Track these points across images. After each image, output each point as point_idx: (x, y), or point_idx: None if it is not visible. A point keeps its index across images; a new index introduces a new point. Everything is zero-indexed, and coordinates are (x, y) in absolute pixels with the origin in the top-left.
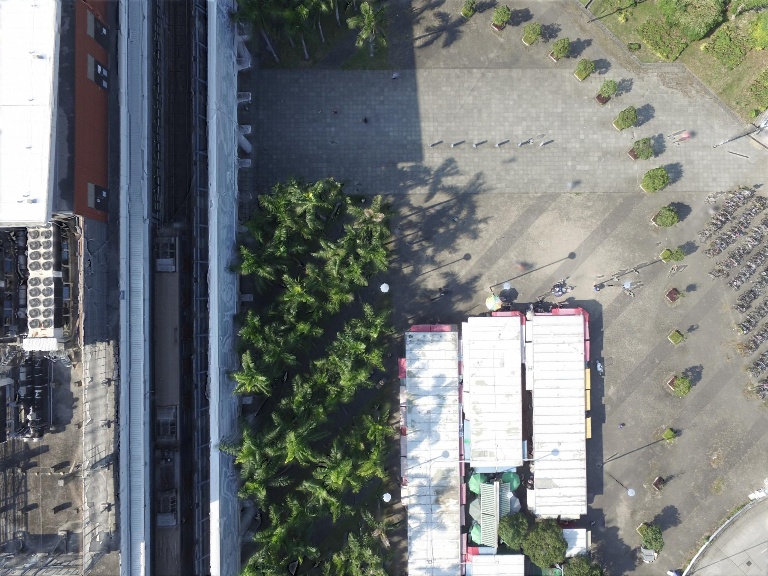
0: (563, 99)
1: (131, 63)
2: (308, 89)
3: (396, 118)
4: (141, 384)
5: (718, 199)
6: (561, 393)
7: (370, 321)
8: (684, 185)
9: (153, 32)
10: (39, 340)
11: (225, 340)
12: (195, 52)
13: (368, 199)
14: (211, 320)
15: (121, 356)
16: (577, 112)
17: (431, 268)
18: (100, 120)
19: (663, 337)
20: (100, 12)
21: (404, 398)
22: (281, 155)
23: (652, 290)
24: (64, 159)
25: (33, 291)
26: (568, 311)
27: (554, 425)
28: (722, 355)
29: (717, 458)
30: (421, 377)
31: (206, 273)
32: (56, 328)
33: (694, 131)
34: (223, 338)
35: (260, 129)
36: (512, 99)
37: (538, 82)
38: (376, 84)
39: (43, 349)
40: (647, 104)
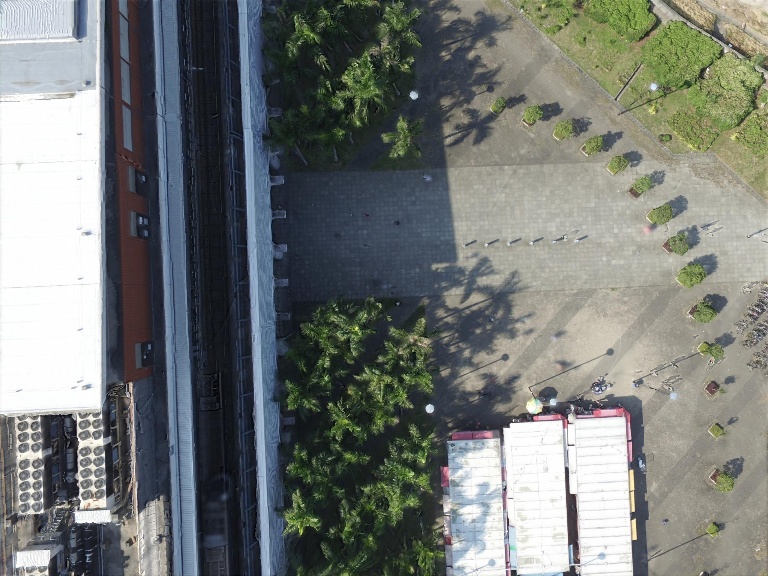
0: (596, 193)
1: (171, 208)
2: (338, 192)
3: (429, 218)
4: (193, 539)
5: (753, 289)
6: (606, 496)
7: (416, 442)
8: (719, 276)
9: (187, 160)
10: (92, 513)
11: (271, 473)
12: (231, 181)
13: (403, 302)
14: (259, 459)
15: (173, 514)
16: (610, 206)
17: (469, 370)
18: (143, 273)
19: (703, 431)
20: (140, 161)
21: (448, 507)
22: (313, 260)
23: (691, 384)
24: (114, 331)
25: (84, 461)
26: (610, 412)
27: (600, 529)
28: (762, 446)
29: (761, 550)
30: (464, 486)
31: (249, 404)
32: (108, 497)
33: (727, 221)
34: (269, 471)
35: (291, 234)
36: (545, 195)
37: (570, 177)
38: (407, 184)
39: (96, 521)
40: (680, 196)
